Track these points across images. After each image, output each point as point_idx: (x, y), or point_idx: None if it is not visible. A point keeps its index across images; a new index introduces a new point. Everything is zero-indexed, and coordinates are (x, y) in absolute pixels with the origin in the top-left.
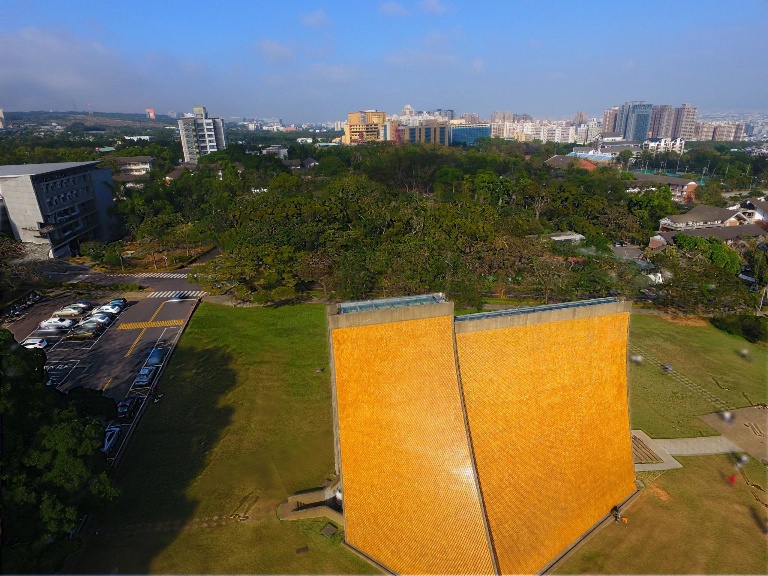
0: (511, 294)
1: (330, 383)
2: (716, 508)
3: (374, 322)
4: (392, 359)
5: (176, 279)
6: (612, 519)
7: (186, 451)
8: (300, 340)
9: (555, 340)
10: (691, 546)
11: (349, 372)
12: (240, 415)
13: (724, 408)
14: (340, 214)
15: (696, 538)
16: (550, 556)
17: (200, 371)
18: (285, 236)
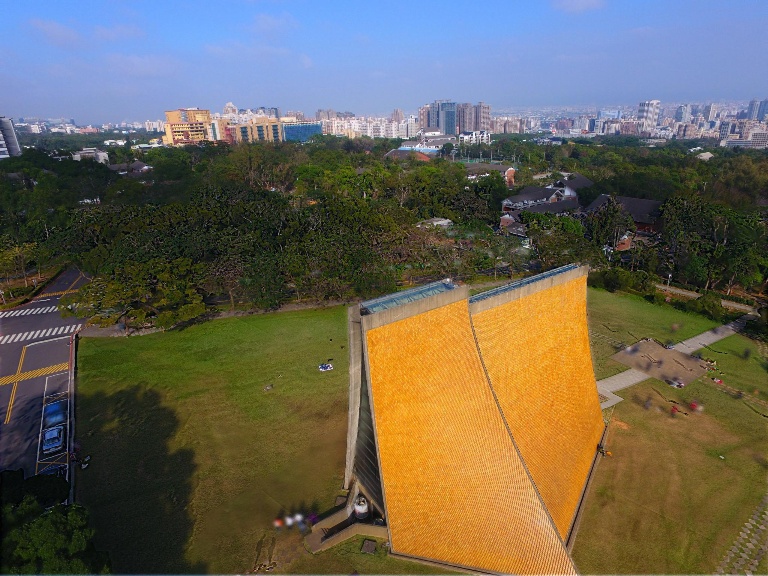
0: (418, 280)
1: (287, 398)
2: (660, 425)
3: (404, 316)
4: (422, 352)
5: (26, 316)
6: (600, 456)
7: (158, 514)
8: (229, 360)
9: (540, 309)
10: (661, 460)
11: (383, 373)
12: (203, 456)
13: (623, 347)
14: (226, 218)
15: (661, 452)
16: (575, 502)
17: (125, 418)
18: (176, 247)
